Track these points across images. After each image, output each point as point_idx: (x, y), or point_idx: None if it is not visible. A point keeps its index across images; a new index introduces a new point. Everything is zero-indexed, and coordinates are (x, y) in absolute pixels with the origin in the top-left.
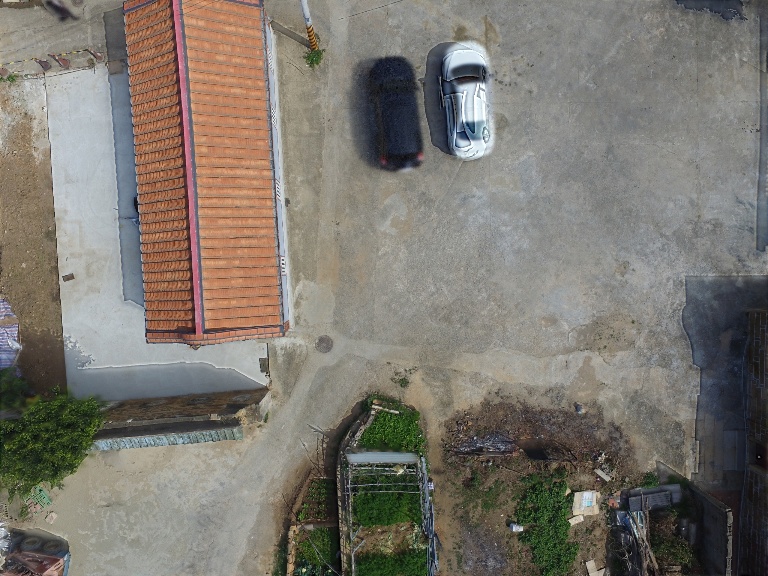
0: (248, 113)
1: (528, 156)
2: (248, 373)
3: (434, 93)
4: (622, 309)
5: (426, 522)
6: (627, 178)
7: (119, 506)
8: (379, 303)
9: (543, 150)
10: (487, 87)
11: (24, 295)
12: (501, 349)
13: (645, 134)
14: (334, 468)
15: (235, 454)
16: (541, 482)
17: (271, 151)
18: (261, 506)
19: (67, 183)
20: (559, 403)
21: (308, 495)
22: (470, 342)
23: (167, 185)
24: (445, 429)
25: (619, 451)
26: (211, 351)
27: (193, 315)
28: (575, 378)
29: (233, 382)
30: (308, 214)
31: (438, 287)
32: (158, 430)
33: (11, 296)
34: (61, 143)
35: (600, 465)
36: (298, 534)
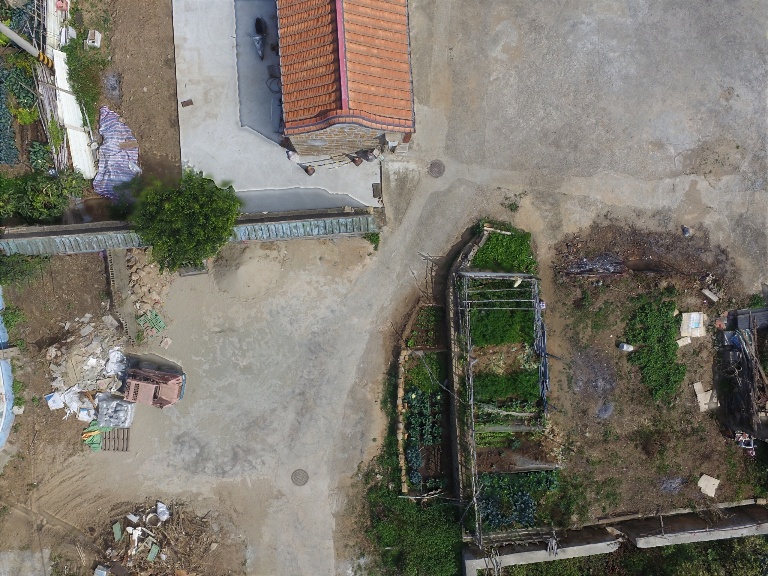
0: None
1: None
2: (361, 198)
3: None
4: (727, 134)
5: (538, 341)
6: (731, 6)
7: (232, 332)
8: (490, 128)
9: None
10: None
11: (144, 120)
12: (610, 172)
13: None
14: (443, 295)
15: (346, 282)
16: (650, 302)
17: None
18: (371, 334)
19: (187, 11)
20: (666, 226)
21: (417, 323)
22: (579, 166)
23: None
24: (555, 252)
25: (725, 273)
26: (325, 176)
27: (337, 95)
28: (682, 201)
29: None
30: (422, 39)
31: (548, 112)
32: None
33: (132, 120)
34: None
35: (708, 286)
36: (407, 361)
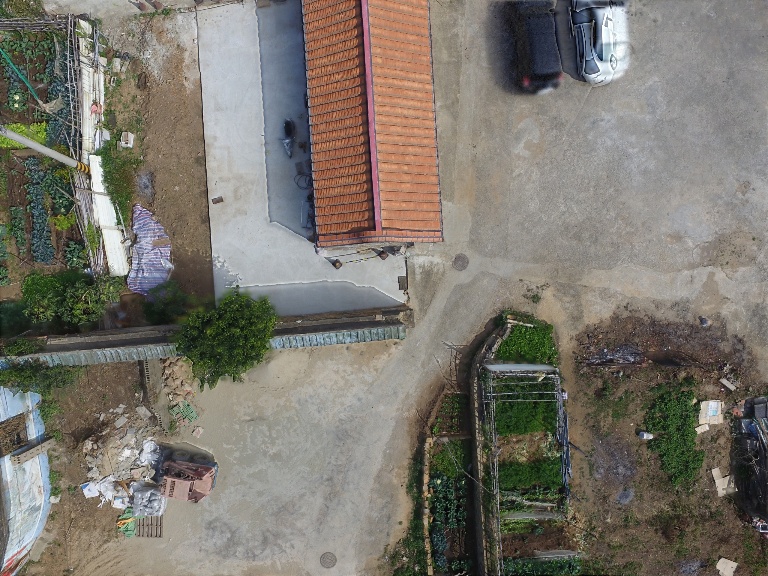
0: (413, 29)
1: (653, 82)
2: (387, 291)
3: (564, 23)
4: (743, 227)
5: None
6: (747, 102)
7: (262, 421)
8: (513, 222)
9: (667, 76)
10: (614, 17)
11: (176, 217)
12: (629, 265)
13: (763, 61)
14: (467, 383)
15: (372, 370)
16: (669, 392)
17: (432, 67)
18: (397, 421)
19: (216, 111)
20: (685, 316)
21: (442, 410)
22: (599, 259)
23: (342, 95)
24: (576, 342)
25: (742, 362)
26: (352, 270)
27: (370, 214)
28: (699, 293)
29: (372, 300)
30: (446, 137)
31: (569, 207)
32: (328, 329)
33: (164, 218)
34: (211, 73)
35: (725, 375)
36: (432, 447)
